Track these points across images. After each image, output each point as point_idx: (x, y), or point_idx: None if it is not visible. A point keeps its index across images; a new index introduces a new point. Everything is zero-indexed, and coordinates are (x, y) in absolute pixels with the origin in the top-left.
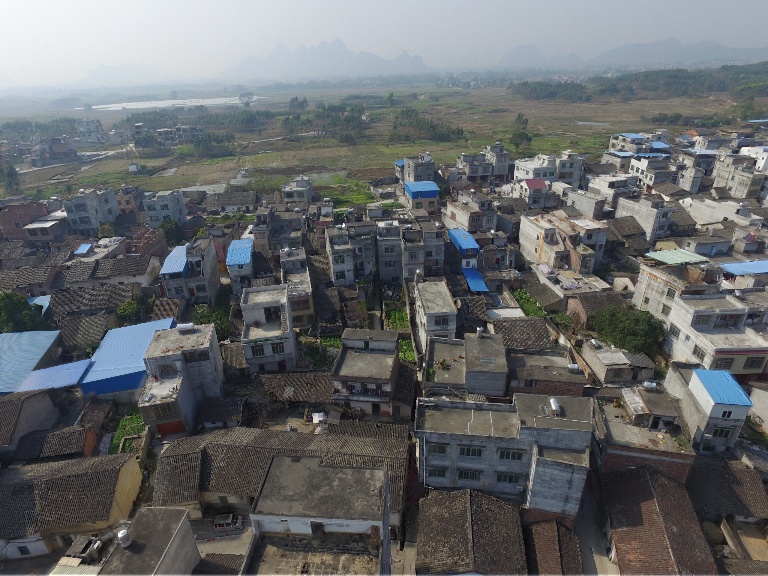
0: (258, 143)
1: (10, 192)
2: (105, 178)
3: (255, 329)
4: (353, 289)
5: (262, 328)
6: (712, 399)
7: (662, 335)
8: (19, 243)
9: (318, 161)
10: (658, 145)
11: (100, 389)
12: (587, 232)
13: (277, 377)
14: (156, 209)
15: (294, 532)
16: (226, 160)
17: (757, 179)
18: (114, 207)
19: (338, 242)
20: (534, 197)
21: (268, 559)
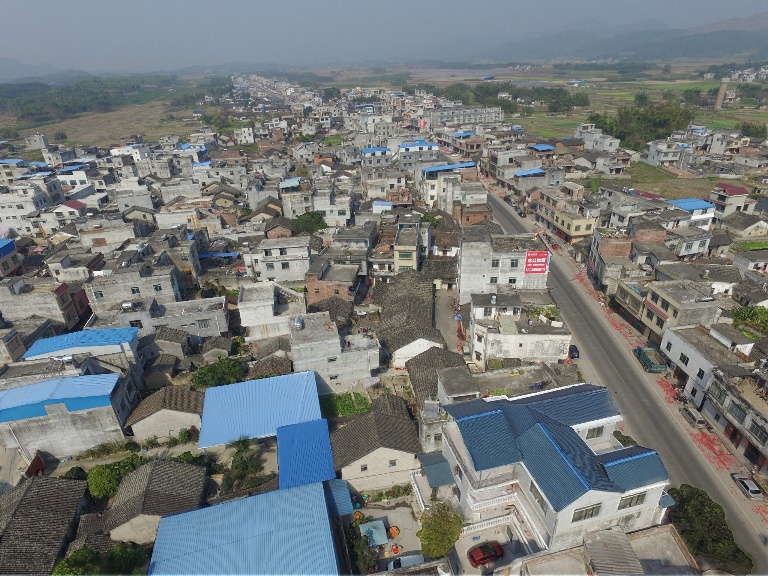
0: None
1: None
2: None
3: (283, 314)
4: None
5: (282, 312)
6: (389, 206)
7: (321, 217)
8: None
9: None
10: (41, 164)
11: None
12: None
13: None
14: None
15: None
16: None
17: (169, 162)
18: None
19: (144, 275)
20: None
21: None
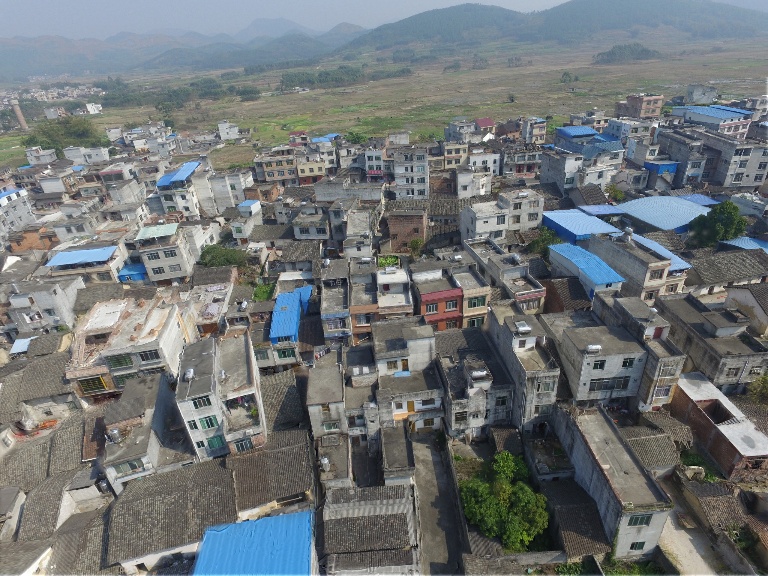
0: None
1: None
2: None
3: None
4: None
5: None
6: None
7: None
8: None
9: None
10: None
11: None
12: None
13: None
14: None
15: None
16: None
17: None
18: None
19: None
20: None
21: None
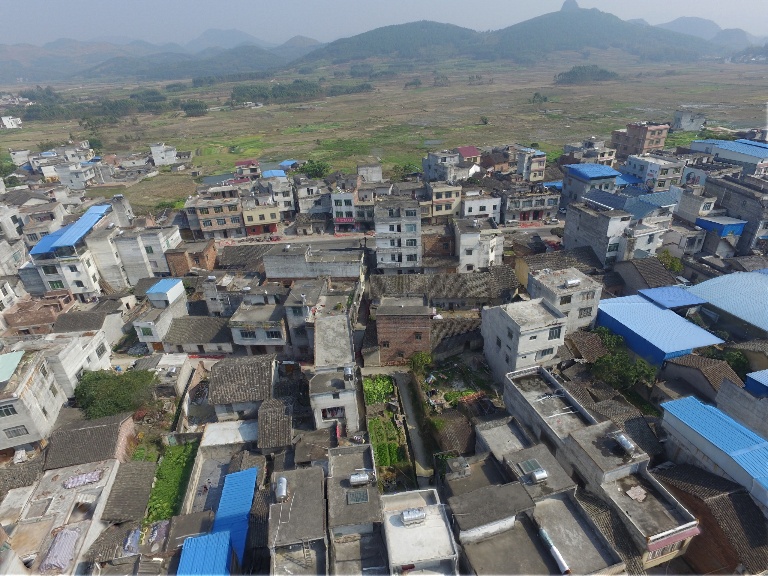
0: None
1: None
2: None
3: None
4: None
5: None
6: (180, 281)
7: None
8: None
9: None
10: None
11: None
12: None
13: None
14: None
15: None
16: None
17: None
18: None
19: None
20: None
21: None
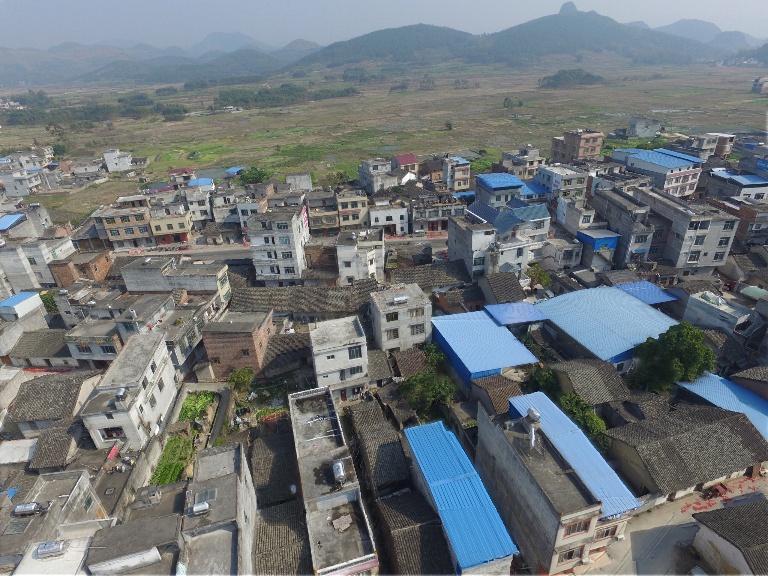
0: None
1: None
2: None
3: None
4: None
5: None
6: None
7: None
8: None
9: None
10: None
11: None
12: None
13: None
14: None
15: None
16: None
17: None
18: None
19: None
20: None
21: None
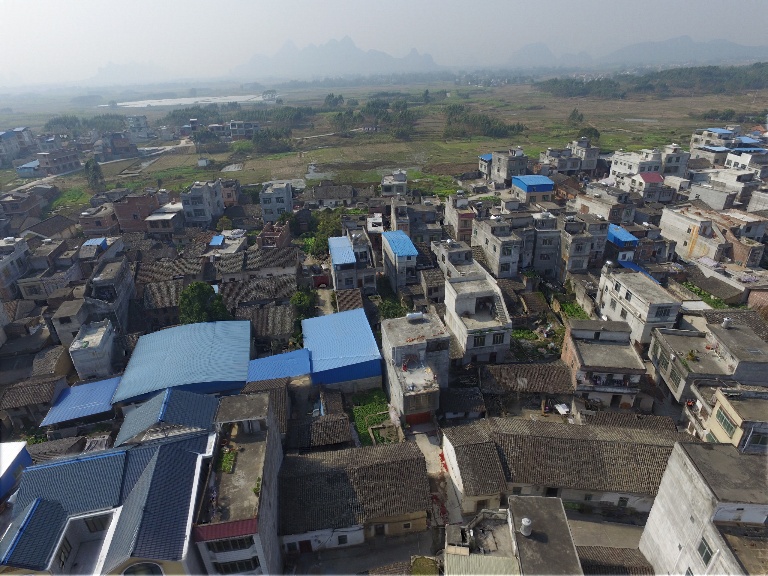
0: (311, 139)
1: (94, 186)
2: (176, 173)
3: (468, 319)
4: (518, 281)
5: (474, 318)
6: None
7: None
8: (141, 235)
9: (383, 156)
10: (747, 140)
11: (328, 379)
12: (747, 225)
13: (505, 368)
14: (271, 202)
15: (744, 521)
16: (288, 155)
17: None
18: (220, 200)
19: (499, 234)
20: (649, 191)
21: (739, 548)
